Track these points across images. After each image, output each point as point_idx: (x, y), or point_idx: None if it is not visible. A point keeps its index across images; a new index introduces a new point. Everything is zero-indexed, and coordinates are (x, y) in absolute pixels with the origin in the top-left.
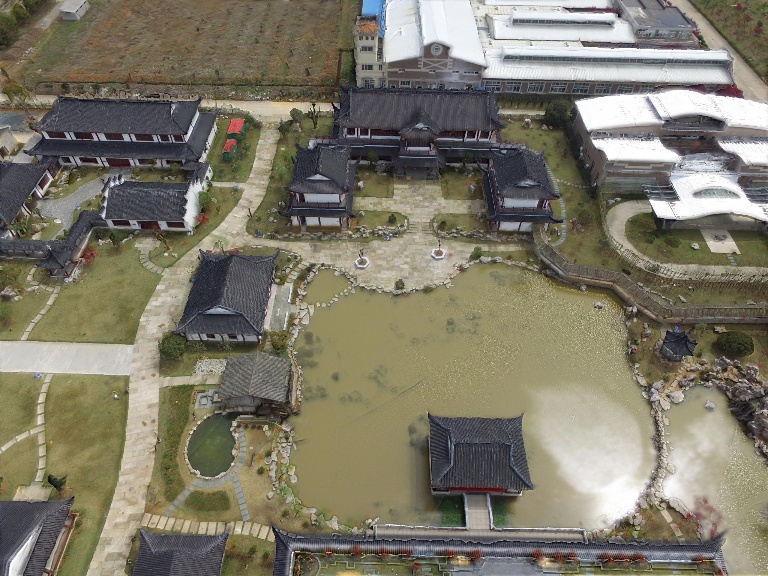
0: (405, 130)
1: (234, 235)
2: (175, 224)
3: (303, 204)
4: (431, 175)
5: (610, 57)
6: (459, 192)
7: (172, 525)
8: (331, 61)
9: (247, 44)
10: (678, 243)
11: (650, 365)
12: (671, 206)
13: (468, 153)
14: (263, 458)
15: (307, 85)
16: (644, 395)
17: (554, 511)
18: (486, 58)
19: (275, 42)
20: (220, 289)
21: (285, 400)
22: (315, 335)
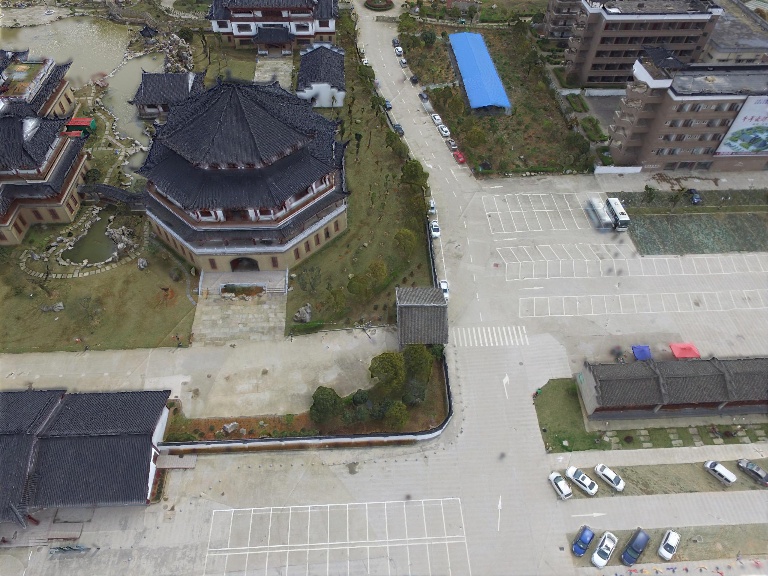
0: None
1: None
2: None
3: None
4: None
5: None
6: None
7: None
8: None
9: None
10: (192, 1)
11: (138, 47)
12: None
13: None
14: None
15: None
16: None
17: None
18: None
19: None
20: None
21: None
22: None
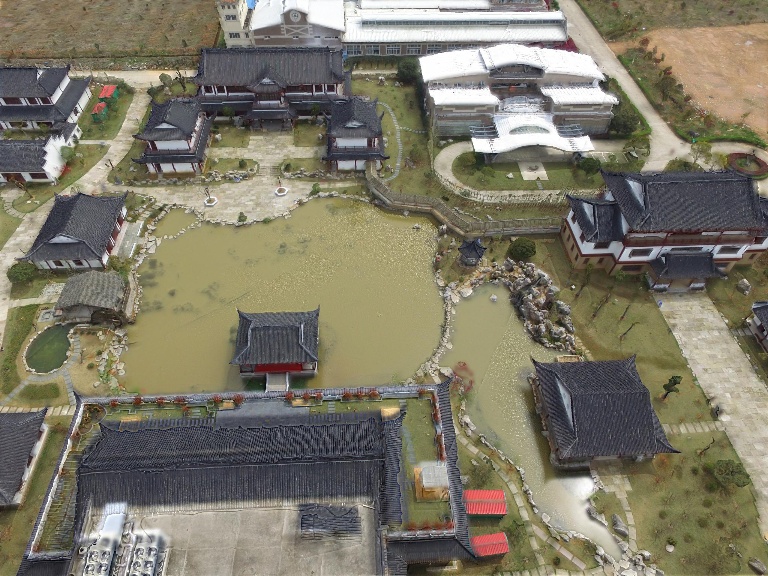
0: (253, 85)
1: (95, 184)
2: (38, 175)
3: (155, 152)
4: (285, 127)
5: (458, 20)
6: (309, 140)
7: (6, 412)
8: (209, 33)
9: (132, 21)
10: (491, 172)
11: (450, 270)
12: (490, 142)
13: (315, 105)
14: (94, 357)
15: (183, 55)
16: (440, 293)
17: (344, 383)
18: (347, 24)
19: (159, 18)
20: (64, 221)
21: (118, 309)
22: (159, 261)
